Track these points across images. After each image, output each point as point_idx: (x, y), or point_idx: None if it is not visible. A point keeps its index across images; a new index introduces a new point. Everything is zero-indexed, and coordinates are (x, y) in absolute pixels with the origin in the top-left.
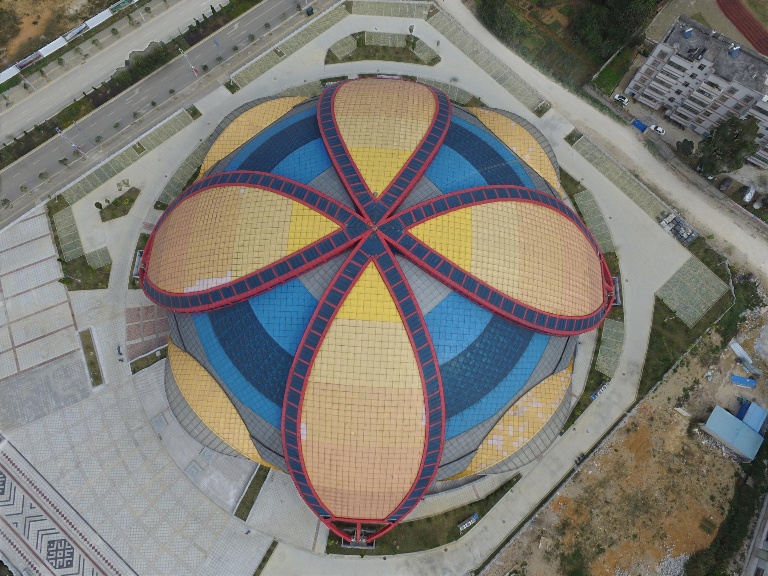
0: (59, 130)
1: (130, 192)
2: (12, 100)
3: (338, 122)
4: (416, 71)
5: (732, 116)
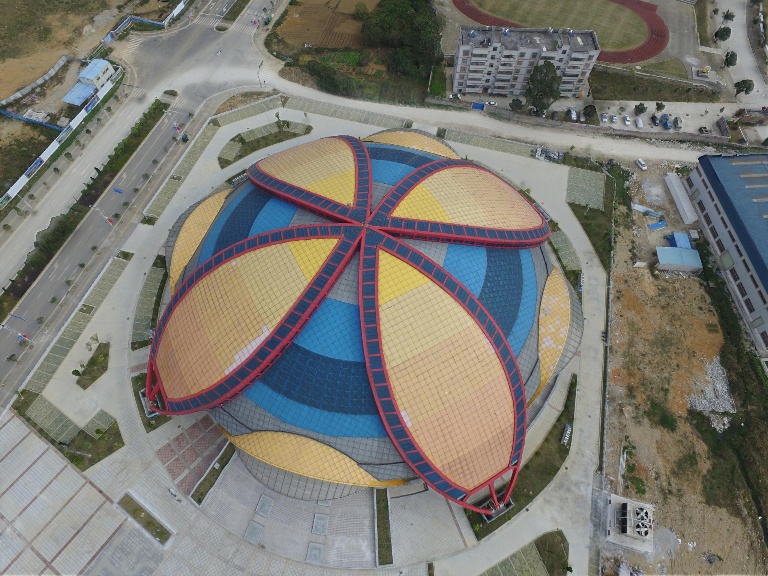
0: (1, 324)
1: (99, 349)
2: None
3: (281, 179)
4: (299, 142)
5: (534, 67)
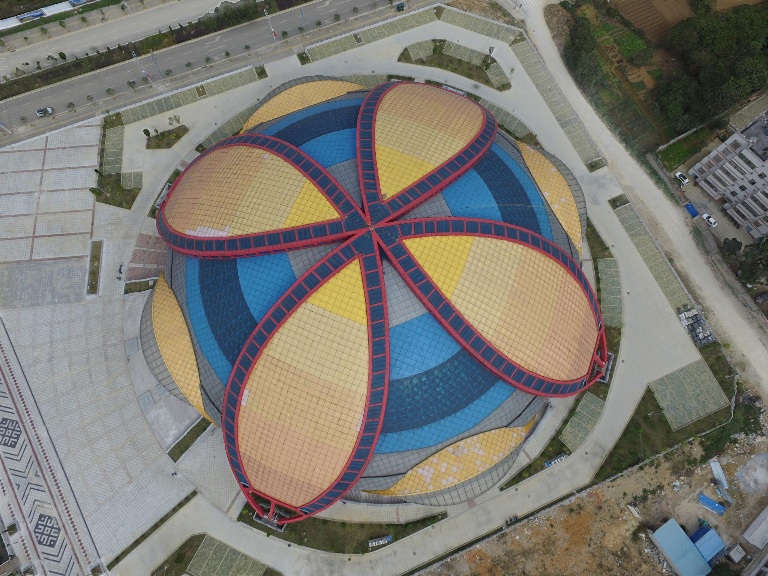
0: (134, 54)
1: (180, 129)
2: (108, 16)
3: (377, 118)
4: (483, 92)
5: None
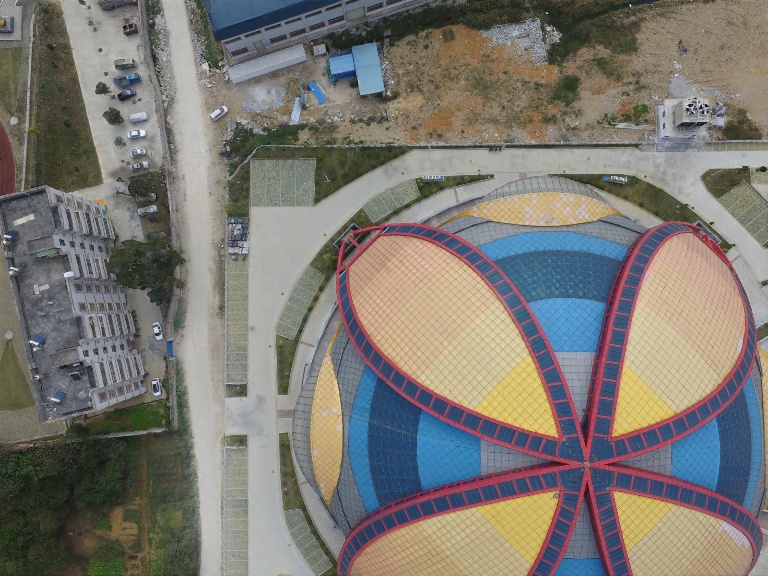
0: None
1: None
2: None
3: None
4: None
5: None
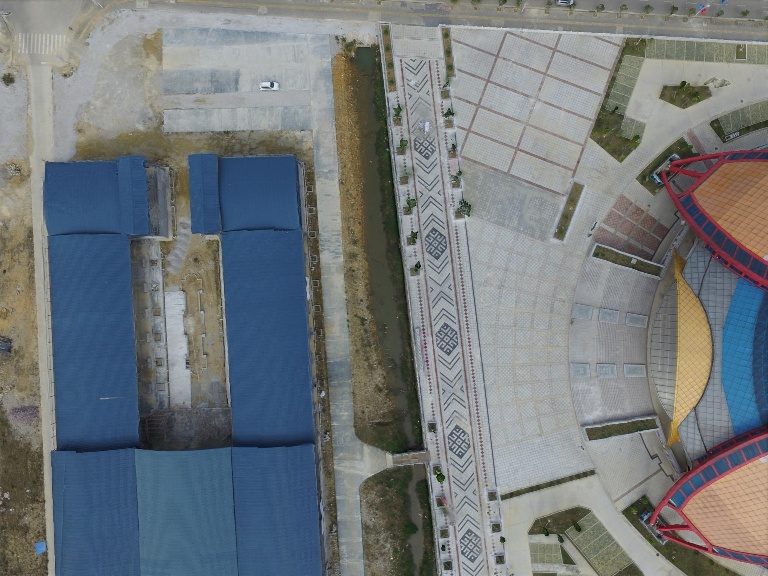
0: None
1: (703, 90)
2: None
3: None
4: None
5: None
